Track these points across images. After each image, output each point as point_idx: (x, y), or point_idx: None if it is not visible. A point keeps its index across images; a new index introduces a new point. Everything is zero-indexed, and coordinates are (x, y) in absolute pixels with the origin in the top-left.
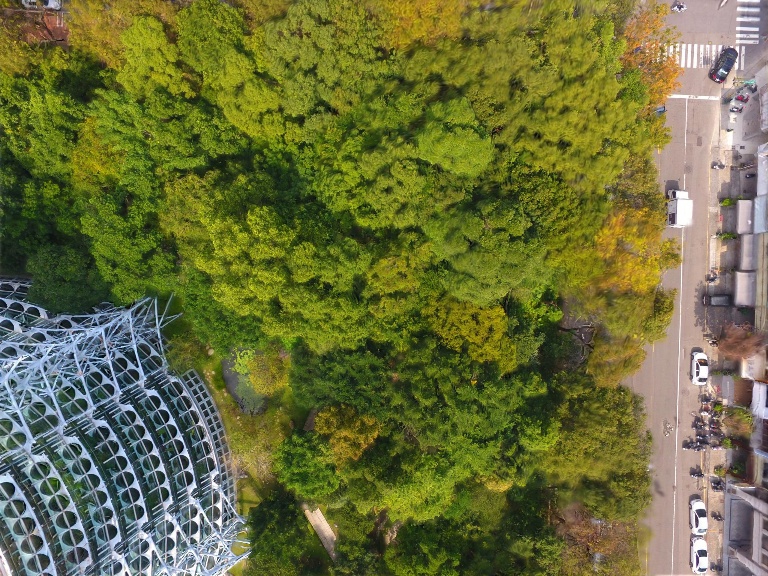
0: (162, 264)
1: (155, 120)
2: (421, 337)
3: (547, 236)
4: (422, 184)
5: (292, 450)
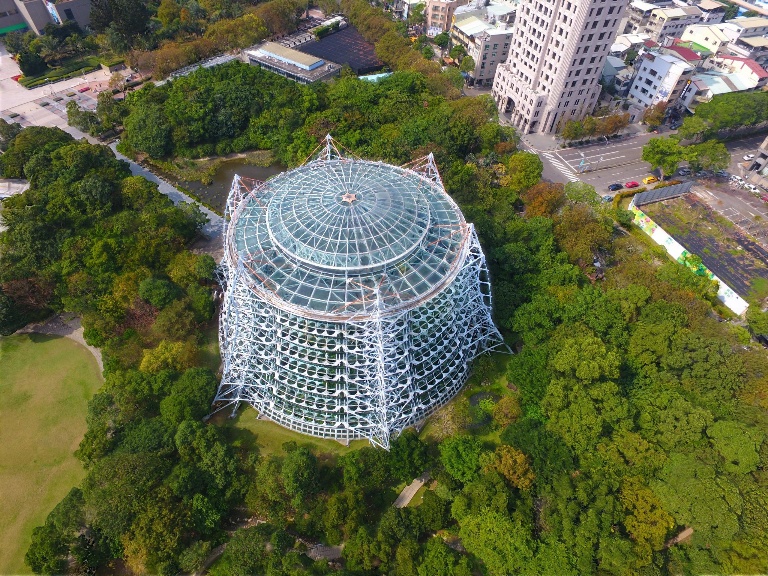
0: (539, 333)
1: (605, 308)
2: None
3: (740, 539)
4: (696, 438)
5: None
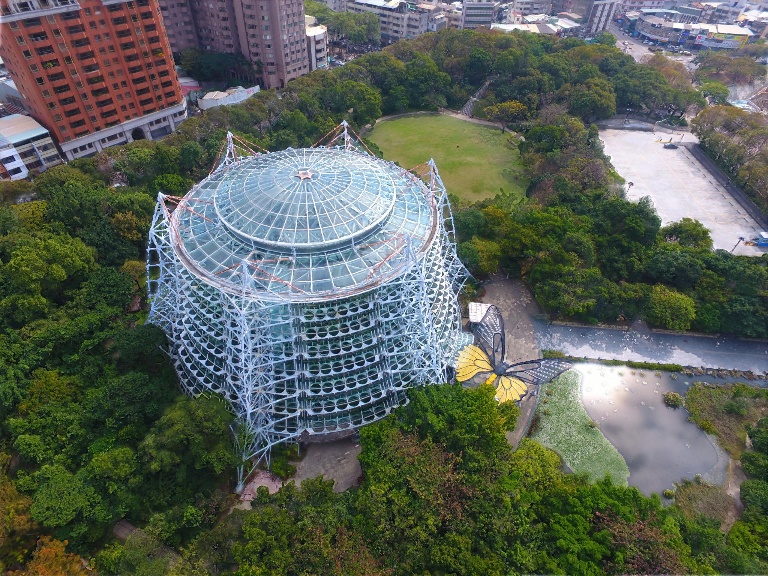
0: None
1: None
2: (49, 220)
3: None
4: None
5: None
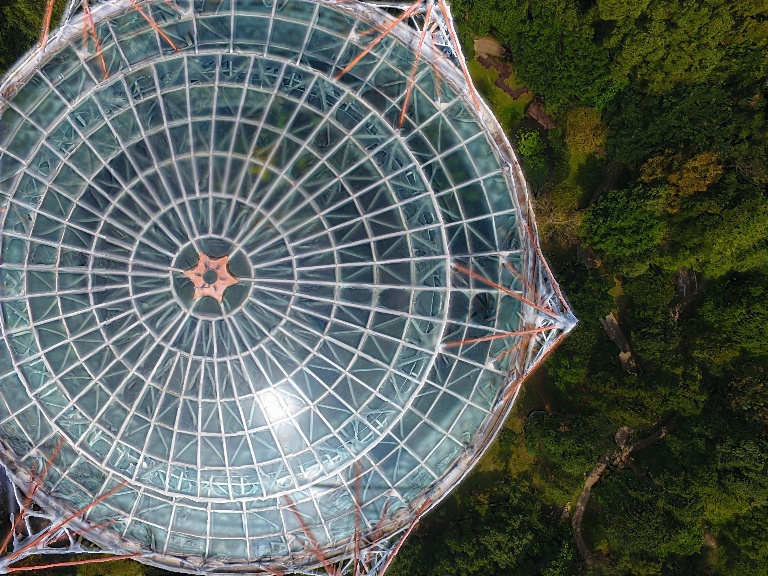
0: None
1: None
2: None
3: None
4: None
5: (611, 204)
